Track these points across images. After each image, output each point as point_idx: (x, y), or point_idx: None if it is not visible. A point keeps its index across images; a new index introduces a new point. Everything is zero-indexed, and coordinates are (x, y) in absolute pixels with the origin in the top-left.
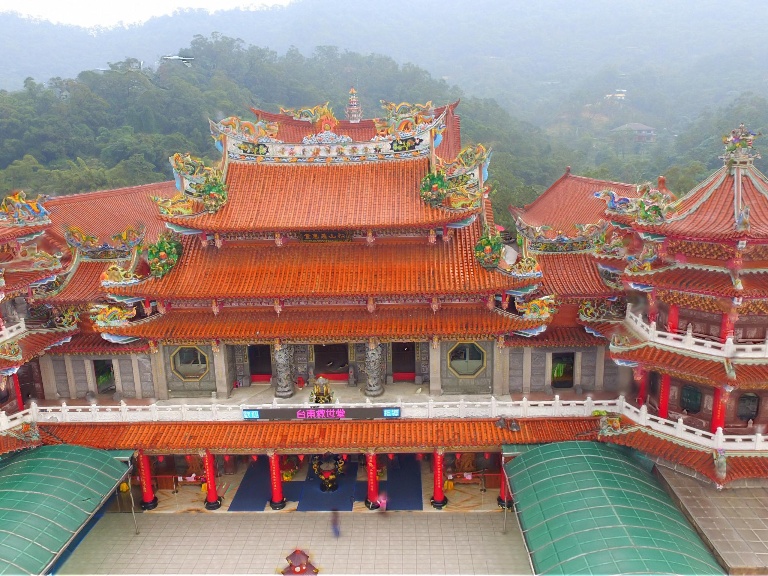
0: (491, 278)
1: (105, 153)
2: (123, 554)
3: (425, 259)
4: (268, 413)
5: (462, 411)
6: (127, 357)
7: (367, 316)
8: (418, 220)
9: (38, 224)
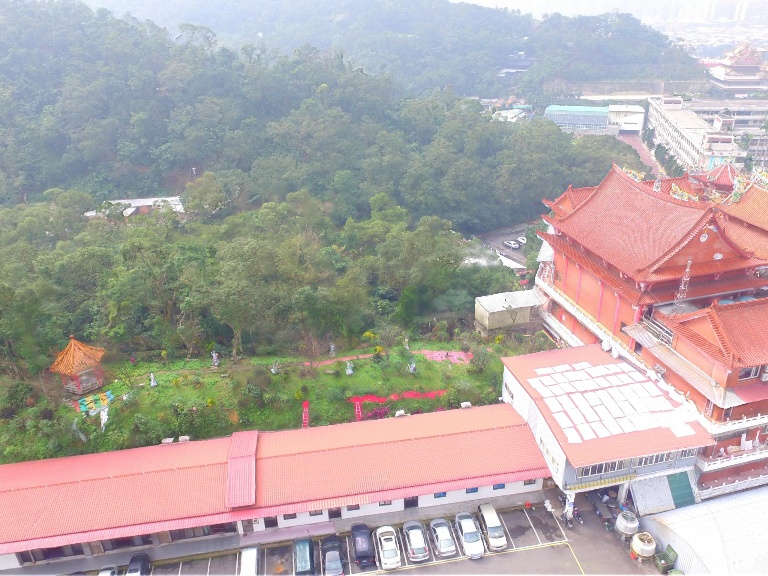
0: None
1: None
2: None
3: None
4: None
5: None
6: None
7: None
8: None
9: None
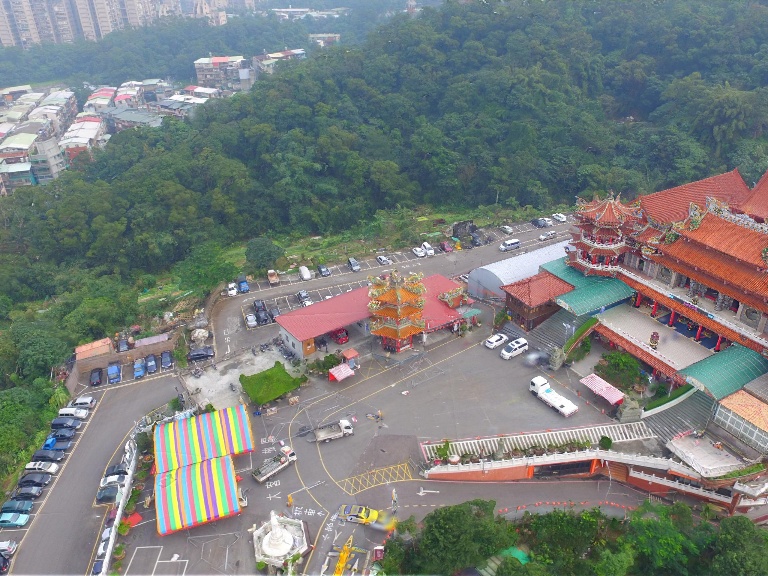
0: (767, 292)
1: (755, 70)
2: (623, 314)
3: (753, 275)
4: (676, 298)
5: (732, 327)
6: (649, 262)
7: (723, 285)
8: (753, 262)
9: (638, 217)
